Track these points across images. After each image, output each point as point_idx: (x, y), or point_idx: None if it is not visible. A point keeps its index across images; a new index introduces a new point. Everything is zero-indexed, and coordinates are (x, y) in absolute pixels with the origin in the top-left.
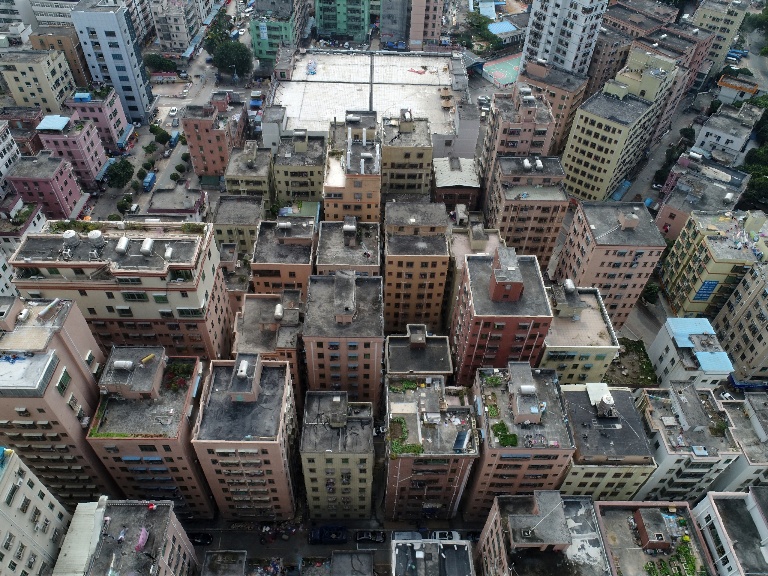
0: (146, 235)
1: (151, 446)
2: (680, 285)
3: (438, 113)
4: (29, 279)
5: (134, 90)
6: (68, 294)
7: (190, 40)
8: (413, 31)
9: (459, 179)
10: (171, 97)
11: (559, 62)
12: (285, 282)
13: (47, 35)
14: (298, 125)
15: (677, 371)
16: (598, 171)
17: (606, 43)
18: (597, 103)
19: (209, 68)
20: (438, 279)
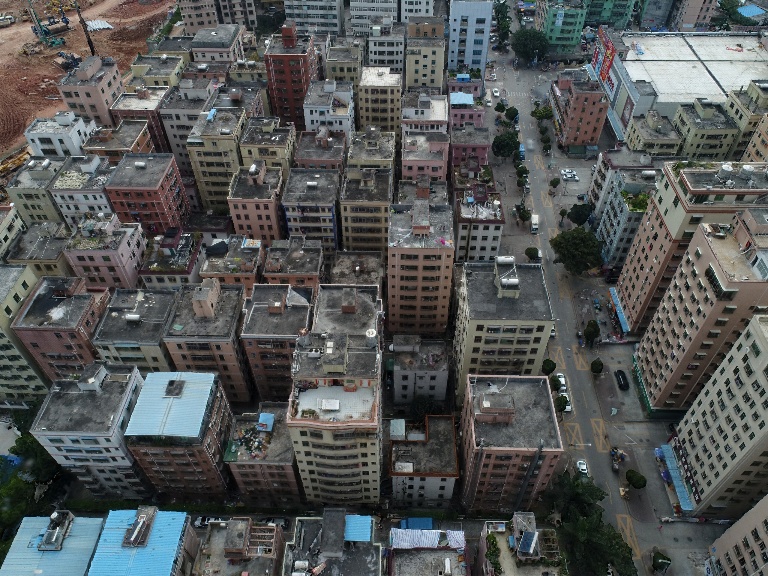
0: None
1: None
2: None
3: None
4: (704, 204)
5: None
6: (724, 217)
7: None
8: (688, 15)
9: None
10: None
11: None
12: None
13: (424, 24)
14: (663, 98)
15: None
16: None
17: None
18: None
19: (498, 54)
20: None
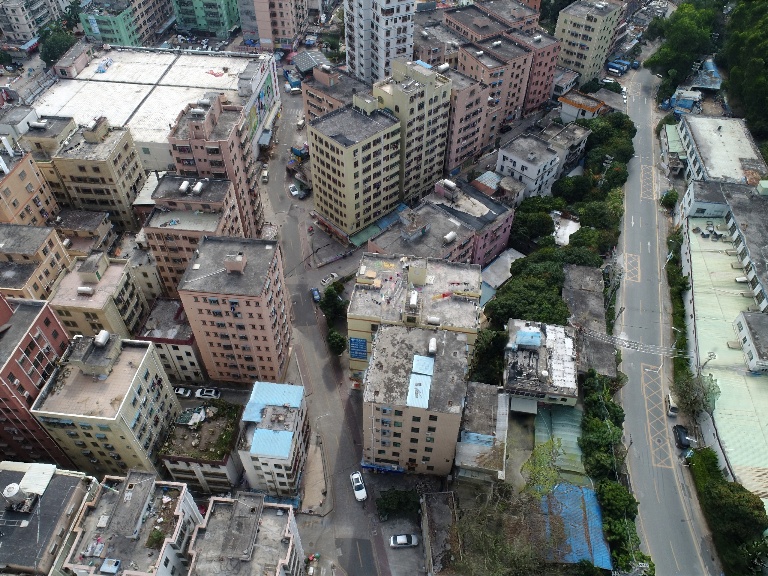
0: None
1: None
2: None
3: None
4: None
5: None
6: None
7: (36, 32)
8: (260, 29)
9: None
10: None
11: (375, 68)
12: None
13: None
14: None
15: None
16: (339, 195)
17: (421, 49)
18: (338, 118)
19: None
20: None
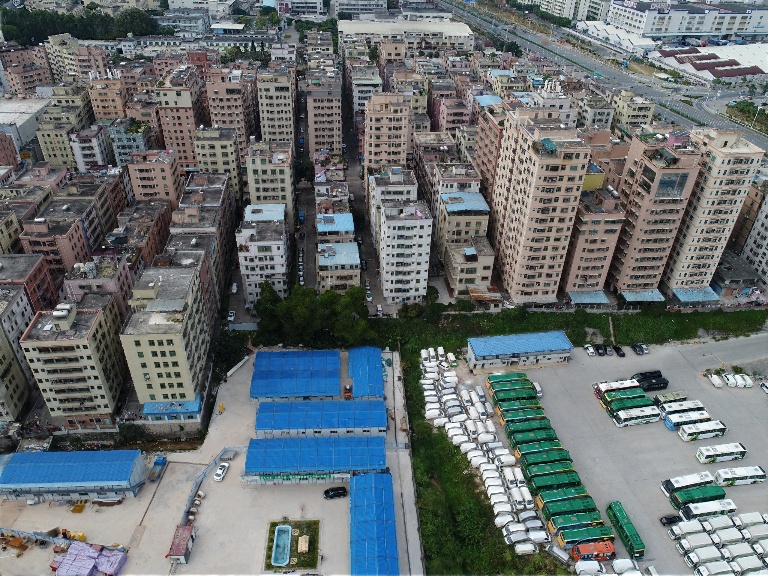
0: None
1: None
2: None
3: (27, 100)
4: None
5: None
6: None
7: None
8: None
9: None
10: None
11: None
12: None
13: None
14: None
15: None
16: None
17: (2, 56)
18: None
19: None
20: None
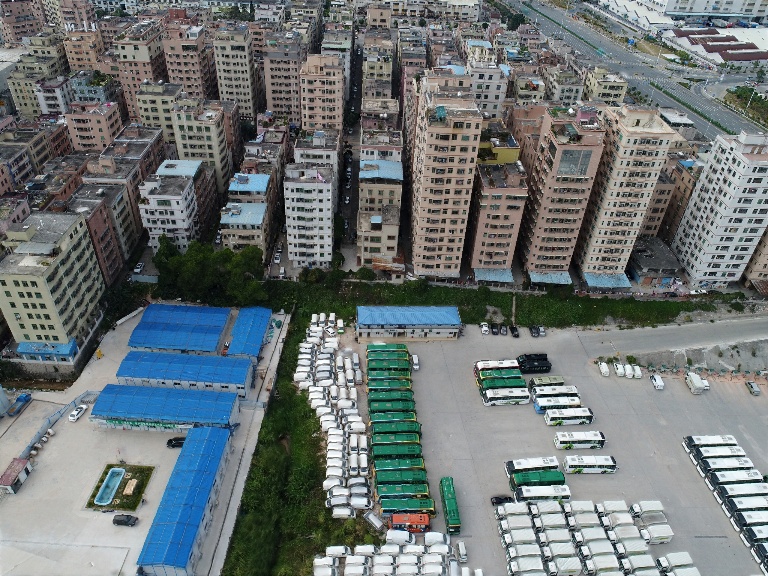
0: None
1: (212, 54)
2: None
3: None
4: (147, 39)
5: None
6: (152, 44)
7: None
8: None
9: None
10: None
11: None
12: None
13: None
14: None
15: None
16: None
17: (0, 6)
18: None
19: None
20: None
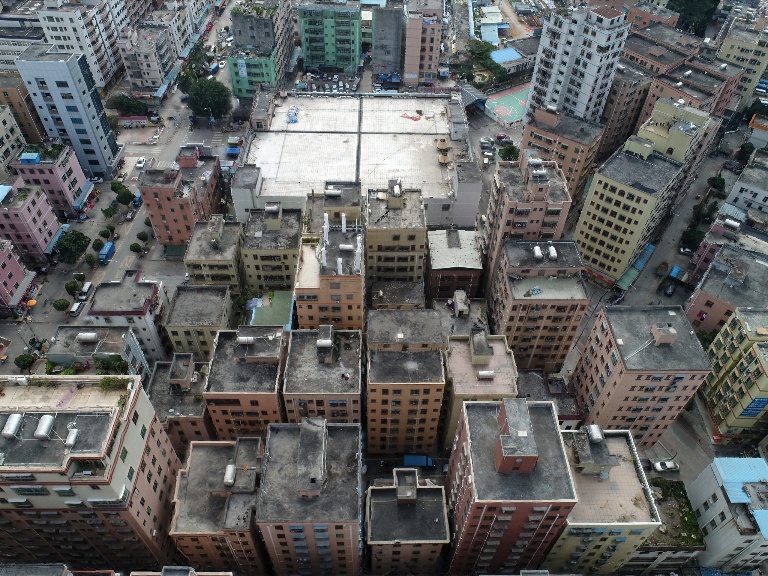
0: (54, 394)
1: None
2: (722, 394)
3: (434, 170)
4: None
5: (93, 143)
6: None
7: (163, 77)
8: (408, 64)
9: (458, 259)
10: (140, 144)
11: (571, 104)
12: (247, 410)
13: None
14: (274, 188)
15: (729, 531)
16: (619, 242)
17: (624, 83)
18: (618, 164)
19: (184, 108)
20: (432, 405)
